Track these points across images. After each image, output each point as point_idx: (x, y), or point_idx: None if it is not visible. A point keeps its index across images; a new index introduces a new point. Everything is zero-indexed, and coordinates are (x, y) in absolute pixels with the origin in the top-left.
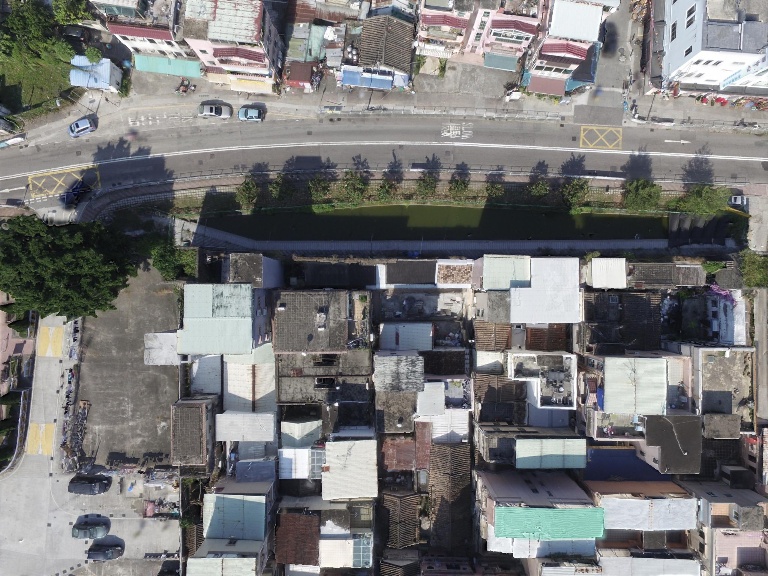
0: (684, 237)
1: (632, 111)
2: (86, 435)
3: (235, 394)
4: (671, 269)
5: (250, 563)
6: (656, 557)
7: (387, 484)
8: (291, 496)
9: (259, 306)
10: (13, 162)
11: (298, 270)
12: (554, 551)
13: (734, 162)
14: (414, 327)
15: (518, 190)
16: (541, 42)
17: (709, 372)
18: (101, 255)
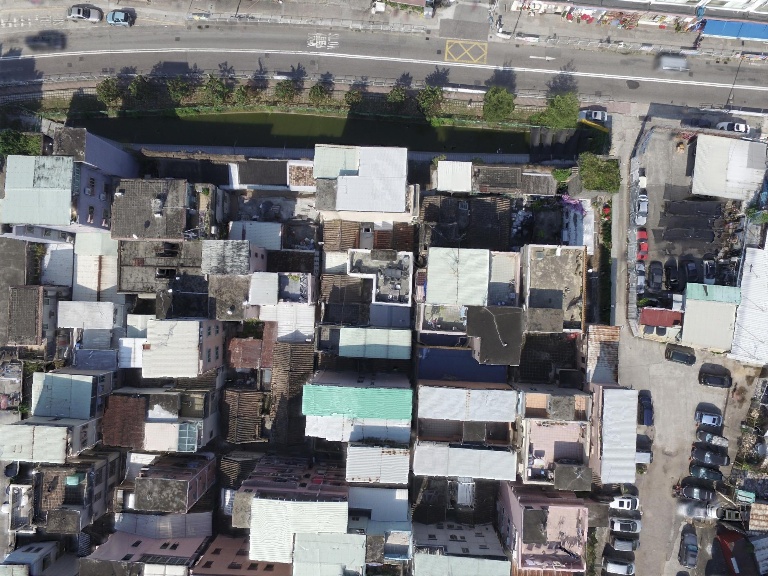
0: (546, 153)
1: (497, 26)
2: None
3: (83, 285)
4: (516, 174)
5: (62, 432)
6: (473, 448)
7: (236, 385)
8: (132, 387)
9: (91, 187)
10: None
11: (152, 167)
12: (367, 436)
13: (599, 80)
14: (262, 225)
15: (381, 101)
16: None
17: (541, 270)
18: None
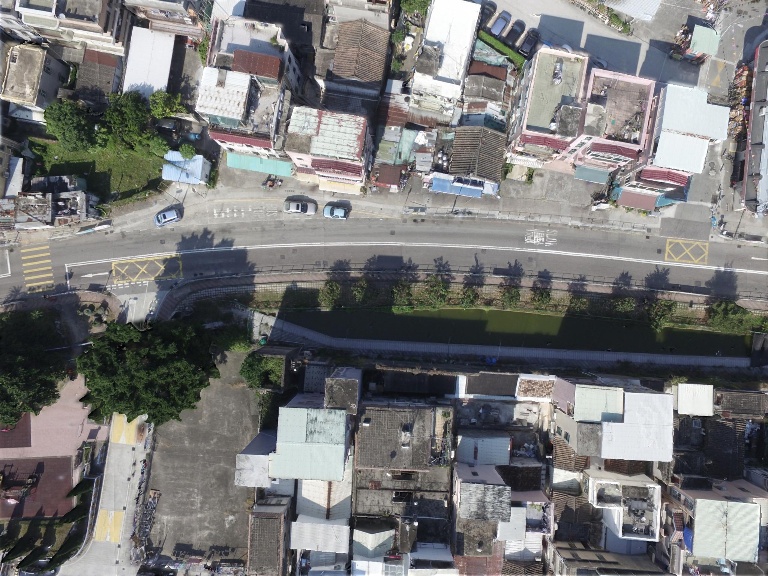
0: (767, 357)
1: (720, 227)
2: (154, 525)
3: (309, 499)
4: (760, 400)
5: None
6: None
7: None
8: None
9: (347, 425)
10: (98, 247)
11: (378, 376)
12: None
13: None
14: (493, 441)
15: (600, 301)
16: (640, 166)
17: None
18: (193, 365)
